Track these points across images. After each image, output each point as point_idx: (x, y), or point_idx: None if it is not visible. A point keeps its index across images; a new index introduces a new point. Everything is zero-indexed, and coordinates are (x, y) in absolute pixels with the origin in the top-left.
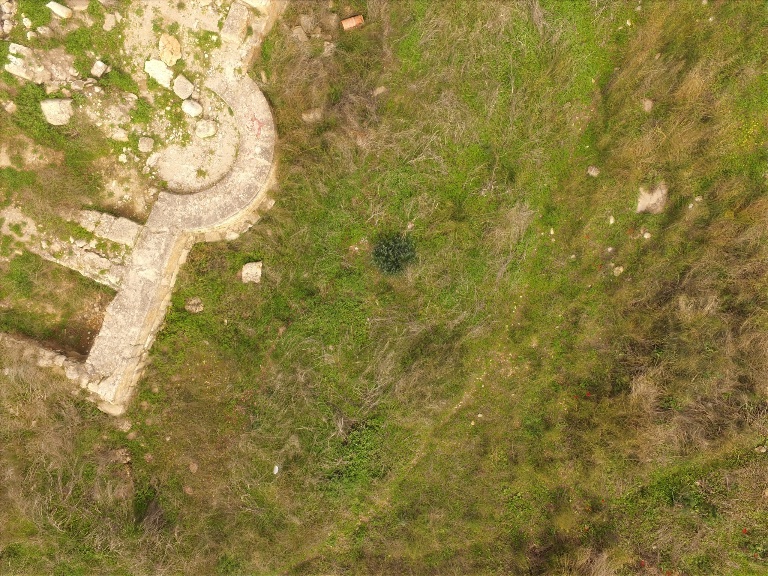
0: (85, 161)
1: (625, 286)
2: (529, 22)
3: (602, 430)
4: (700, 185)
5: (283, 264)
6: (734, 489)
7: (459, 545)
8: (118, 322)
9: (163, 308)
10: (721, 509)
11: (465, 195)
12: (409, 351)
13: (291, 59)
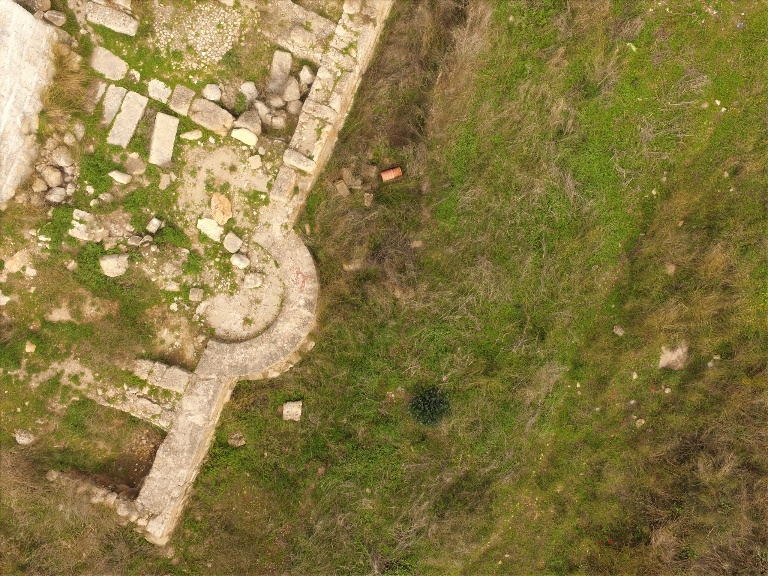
0: (139, 311)
1: (646, 438)
2: (560, 191)
3: None
4: (718, 344)
5: (322, 403)
6: None
7: None
8: (167, 464)
9: (207, 443)
10: None
11: (497, 350)
12: (441, 496)
13: (335, 216)
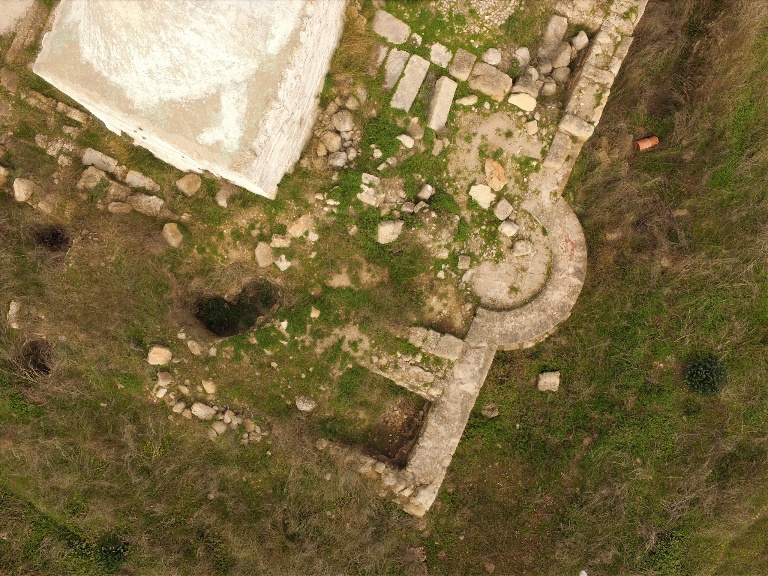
0: (409, 278)
1: None
2: None
3: None
4: None
5: (579, 374)
6: None
7: None
8: (439, 433)
9: None
10: None
11: None
12: (715, 466)
13: (604, 184)
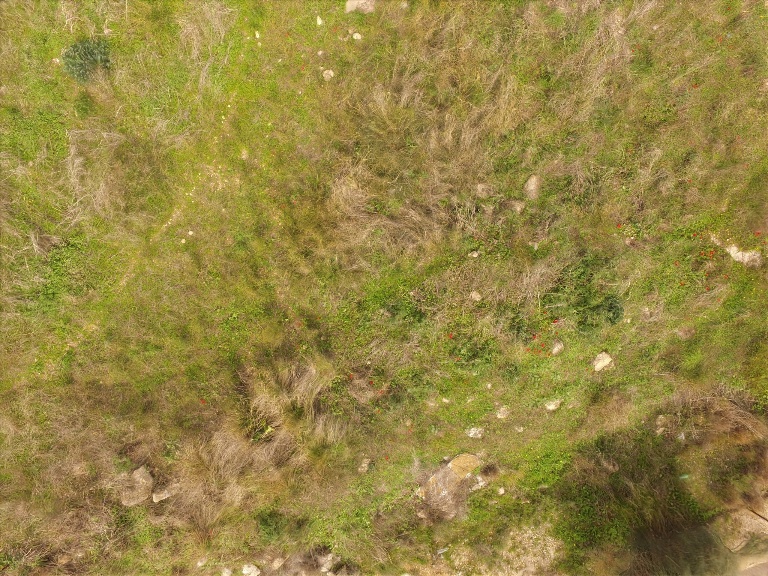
0: None
1: None
2: None
3: (305, 237)
4: None
5: None
6: (443, 295)
7: (173, 369)
8: None
9: None
10: (429, 316)
11: None
12: None
13: None
